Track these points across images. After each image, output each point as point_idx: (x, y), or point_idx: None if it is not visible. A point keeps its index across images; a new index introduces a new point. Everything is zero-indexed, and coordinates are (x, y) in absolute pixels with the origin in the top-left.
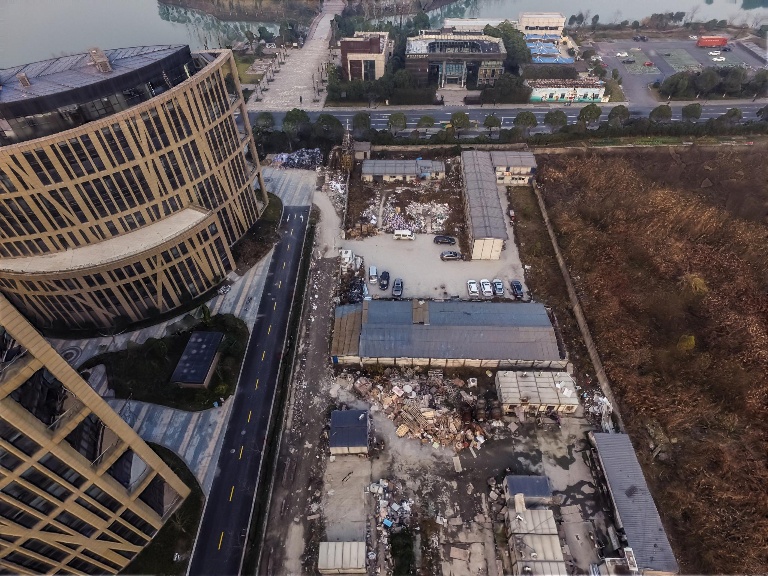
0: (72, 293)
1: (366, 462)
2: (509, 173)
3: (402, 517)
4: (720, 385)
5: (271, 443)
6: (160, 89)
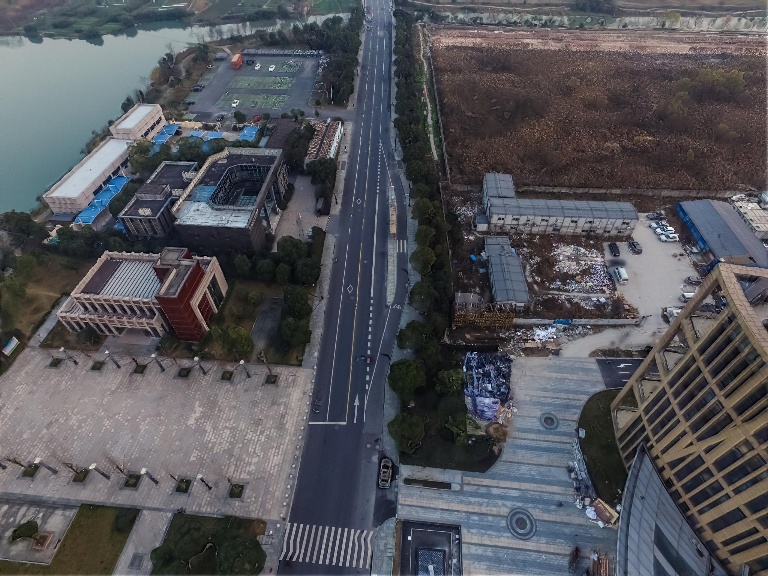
0: None
1: None
2: None
3: None
4: (700, 157)
5: None
6: None
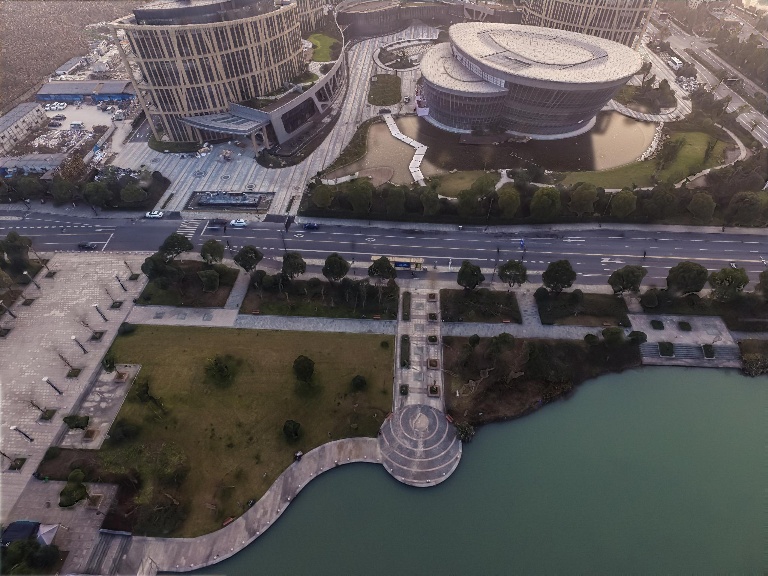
0: None
1: None
2: None
3: None
4: None
5: None
6: None
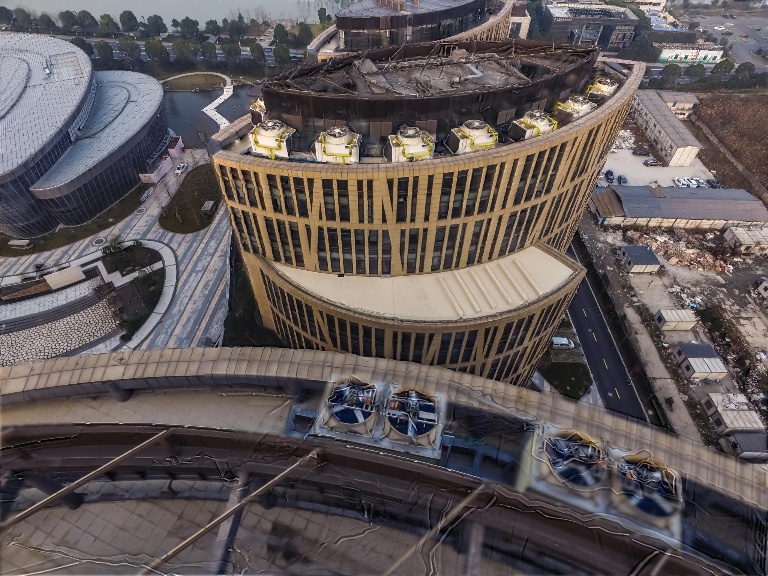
0: None
1: (657, 277)
2: (675, 108)
3: (699, 304)
4: None
5: (590, 263)
6: (481, 16)
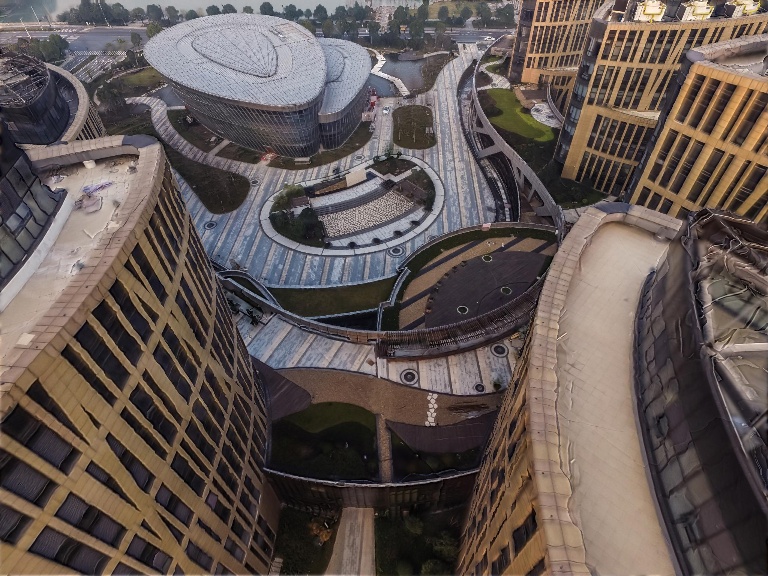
0: None
1: None
2: None
3: None
4: None
5: None
6: None
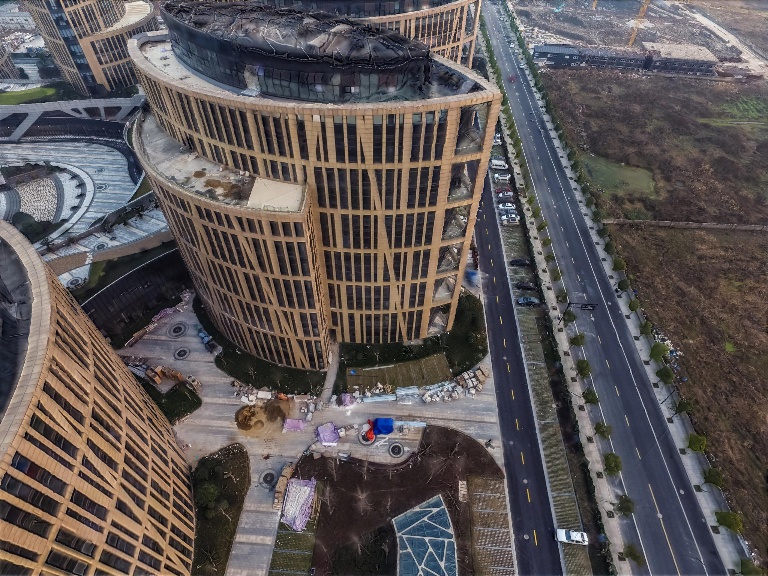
0: (0, 64)
1: None
2: None
3: None
4: None
5: None
6: None
